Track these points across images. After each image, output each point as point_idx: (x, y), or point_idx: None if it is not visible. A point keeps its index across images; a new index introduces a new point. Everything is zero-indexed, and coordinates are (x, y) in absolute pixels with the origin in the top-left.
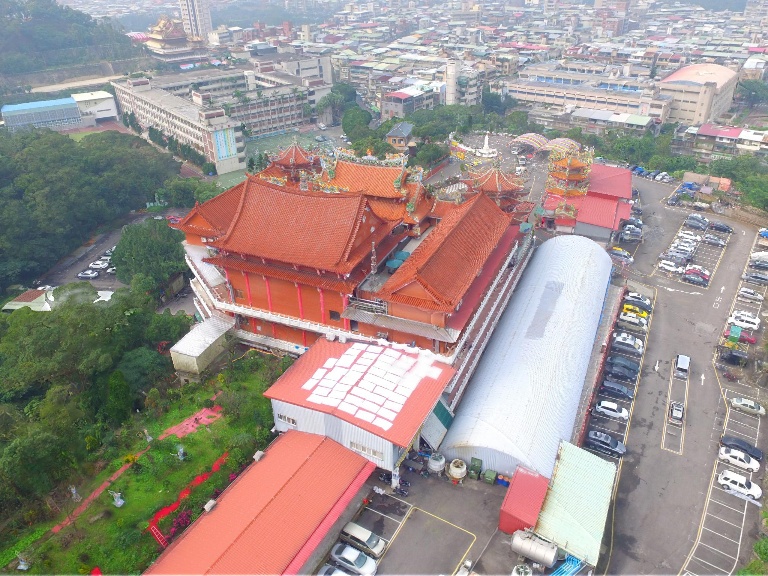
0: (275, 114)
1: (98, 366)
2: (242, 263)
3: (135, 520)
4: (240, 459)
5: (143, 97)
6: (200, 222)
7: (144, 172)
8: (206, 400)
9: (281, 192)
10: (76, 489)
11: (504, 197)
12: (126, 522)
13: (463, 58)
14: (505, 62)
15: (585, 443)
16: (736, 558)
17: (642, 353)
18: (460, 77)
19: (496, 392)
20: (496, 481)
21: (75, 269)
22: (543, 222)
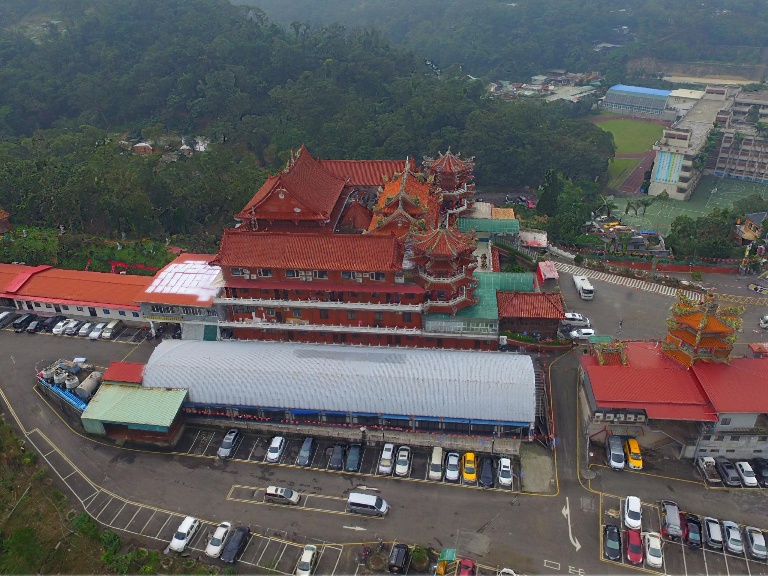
0: None
1: None
2: None
3: (109, 255)
4: None
5: None
6: None
7: (559, 161)
8: None
9: None
10: None
11: None
12: None
13: None
14: None
15: None
16: (110, 525)
17: (382, 472)
18: None
19: (221, 344)
20: None
21: None
22: None
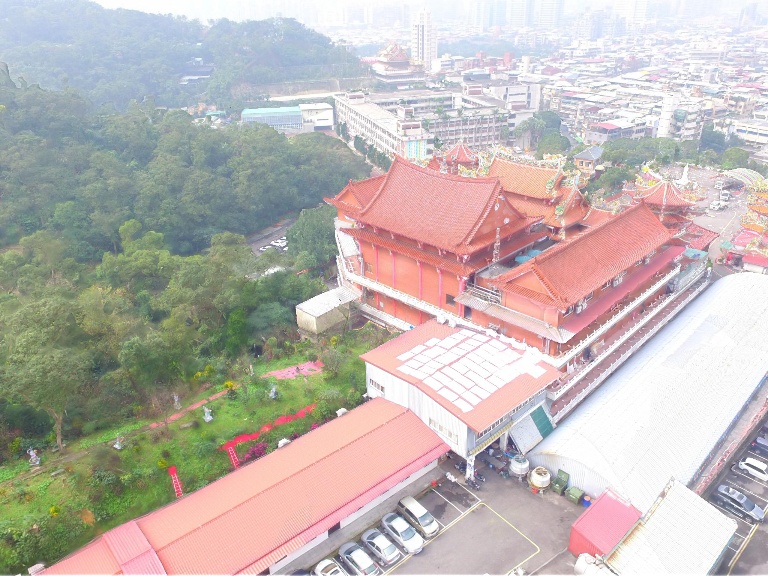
0: (472, 133)
1: (228, 303)
2: (374, 236)
3: (216, 435)
4: (325, 411)
5: (355, 108)
6: (351, 199)
7: (337, 170)
8: (311, 353)
9: (423, 174)
10: (181, 400)
11: (671, 213)
12: (207, 434)
13: (690, 95)
14: (740, 101)
15: (712, 497)
16: None
17: None
18: (677, 110)
19: (607, 410)
20: (581, 501)
21: (259, 244)
22: (730, 259)
